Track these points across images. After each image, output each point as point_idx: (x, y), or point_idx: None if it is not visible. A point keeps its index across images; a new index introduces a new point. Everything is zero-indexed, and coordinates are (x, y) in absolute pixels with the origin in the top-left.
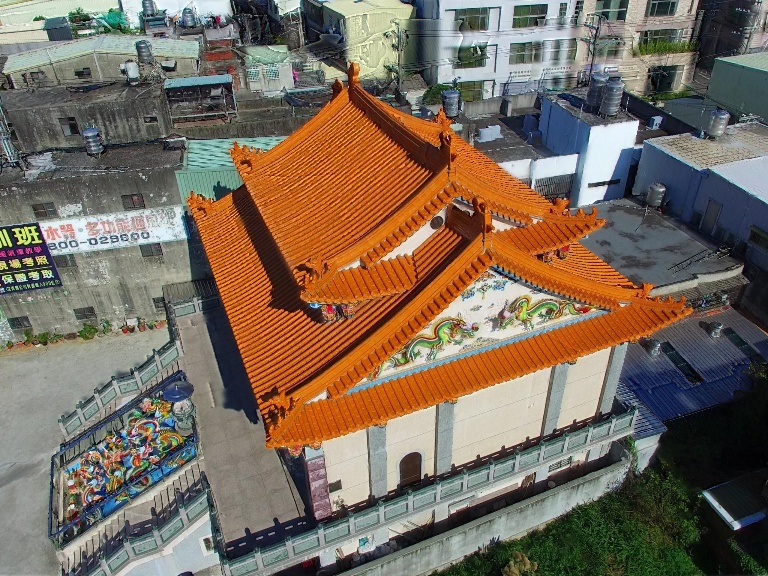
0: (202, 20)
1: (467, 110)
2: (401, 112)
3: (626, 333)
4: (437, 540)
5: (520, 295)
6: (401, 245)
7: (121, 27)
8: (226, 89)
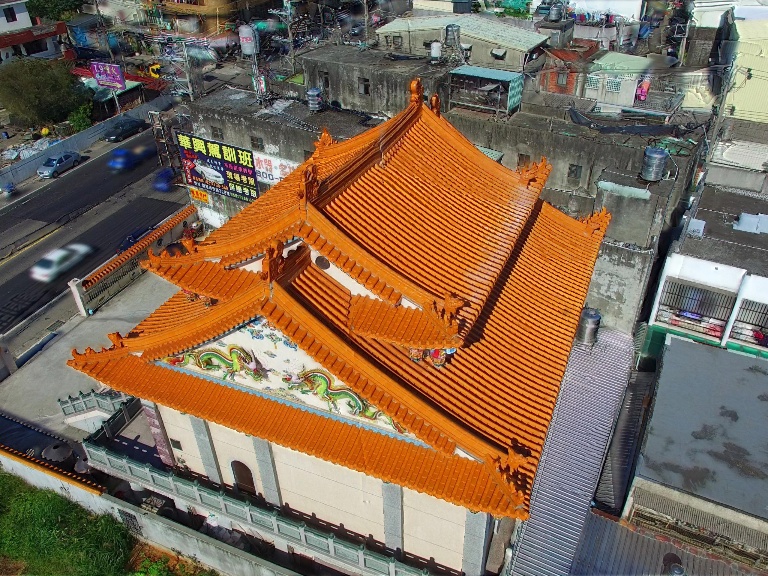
0: (596, 16)
1: (766, 186)
2: (472, 147)
3: (437, 486)
4: (247, 557)
5: (318, 367)
6: (259, 262)
7: (520, 10)
8: (503, 87)
